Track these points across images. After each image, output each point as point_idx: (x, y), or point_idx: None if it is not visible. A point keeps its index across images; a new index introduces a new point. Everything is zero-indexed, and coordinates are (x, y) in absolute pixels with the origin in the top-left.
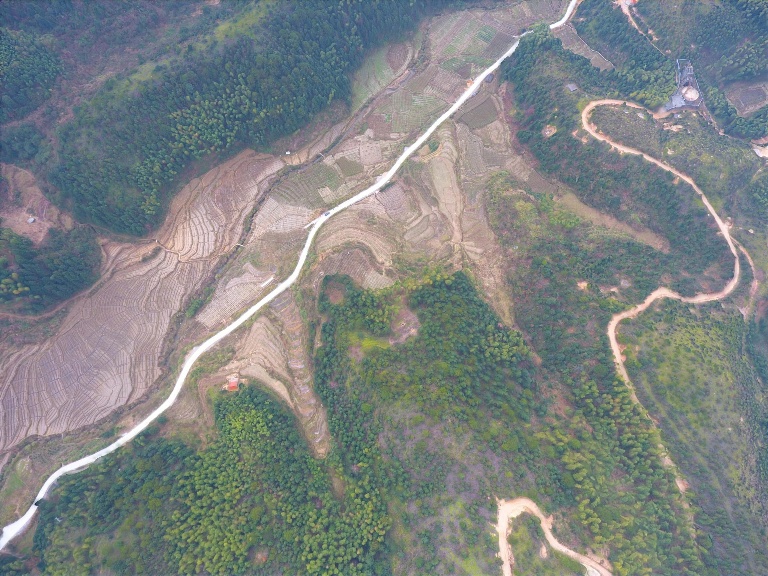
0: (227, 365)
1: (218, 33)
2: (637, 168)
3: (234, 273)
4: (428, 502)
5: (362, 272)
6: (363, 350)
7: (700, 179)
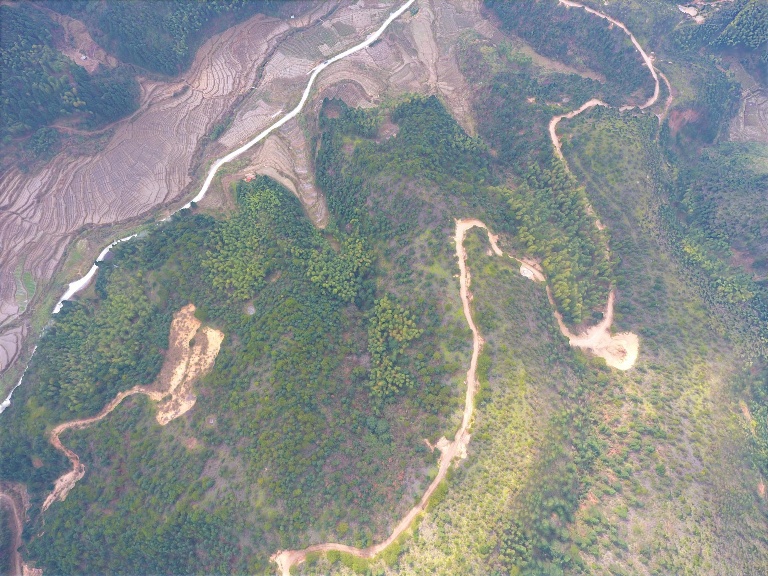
0: (245, 168)
1: None
2: (580, 18)
3: (249, 107)
4: (404, 237)
5: (354, 100)
6: (355, 146)
7: (630, 23)
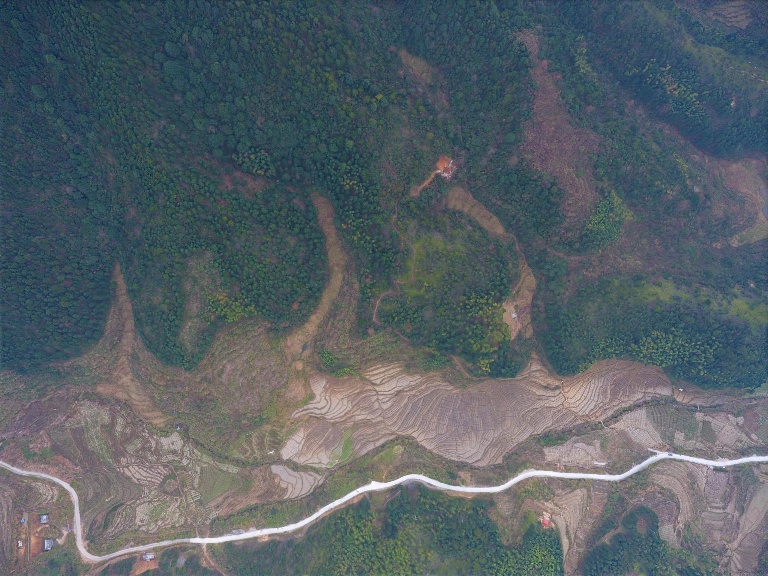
0: (547, 502)
1: (734, 307)
2: None
3: (586, 440)
4: None
5: (665, 520)
6: None
7: None
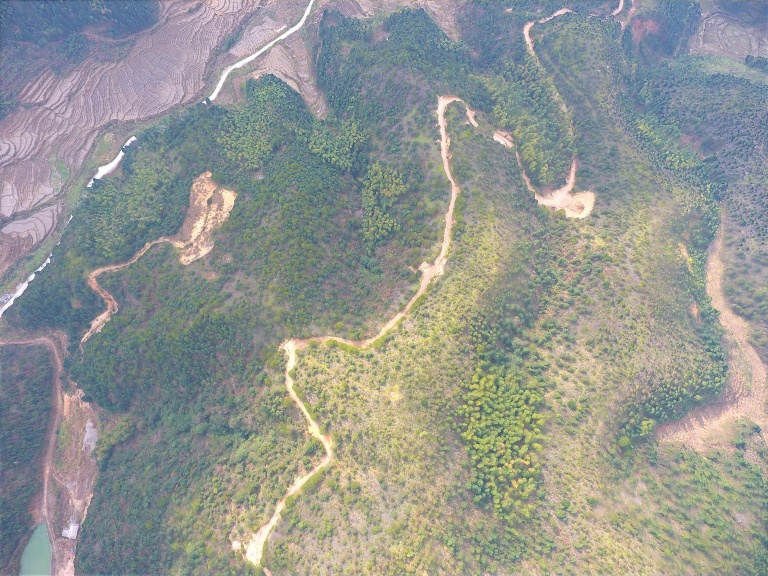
0: (254, 72)
1: None
2: None
3: (257, 22)
4: (394, 117)
5: (351, 14)
6: None
7: None
